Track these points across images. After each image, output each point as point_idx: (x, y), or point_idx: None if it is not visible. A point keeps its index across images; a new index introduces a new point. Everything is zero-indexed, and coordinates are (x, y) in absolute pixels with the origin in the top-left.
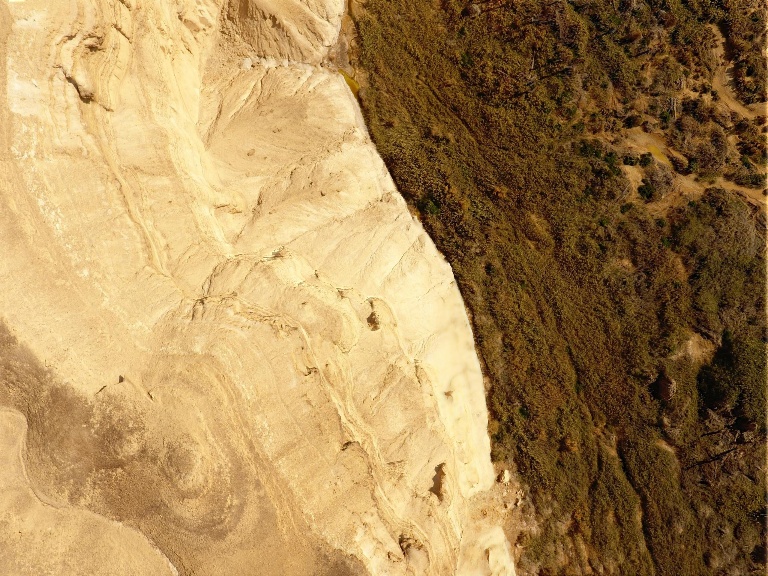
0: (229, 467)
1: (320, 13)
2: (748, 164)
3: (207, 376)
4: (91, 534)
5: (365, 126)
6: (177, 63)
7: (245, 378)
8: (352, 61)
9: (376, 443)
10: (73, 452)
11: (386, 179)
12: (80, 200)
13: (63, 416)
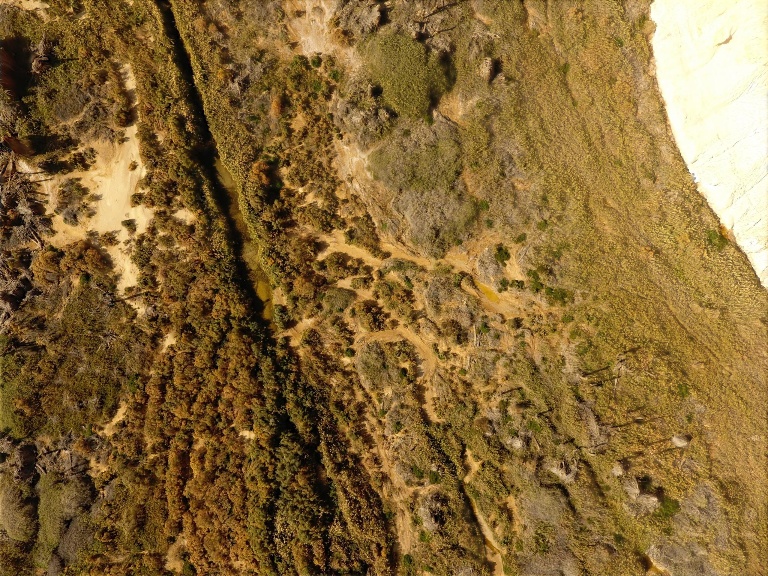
0: None
1: None
2: (408, 280)
3: None
4: None
5: None
6: None
7: None
8: None
9: None
10: None
11: (767, 263)
12: None
13: None
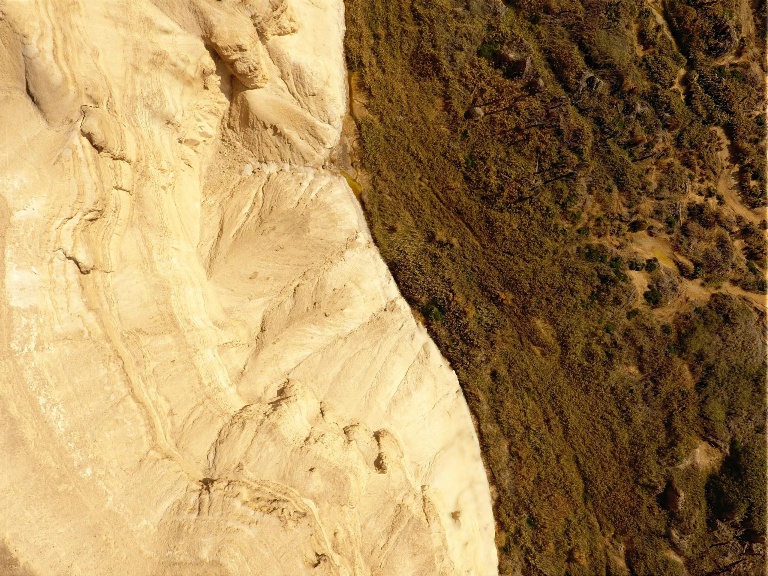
0: None
1: (321, 117)
2: (754, 270)
3: None
4: None
5: (368, 229)
6: (177, 186)
7: None
8: (354, 163)
9: None
10: None
11: (390, 286)
12: (82, 390)
13: None
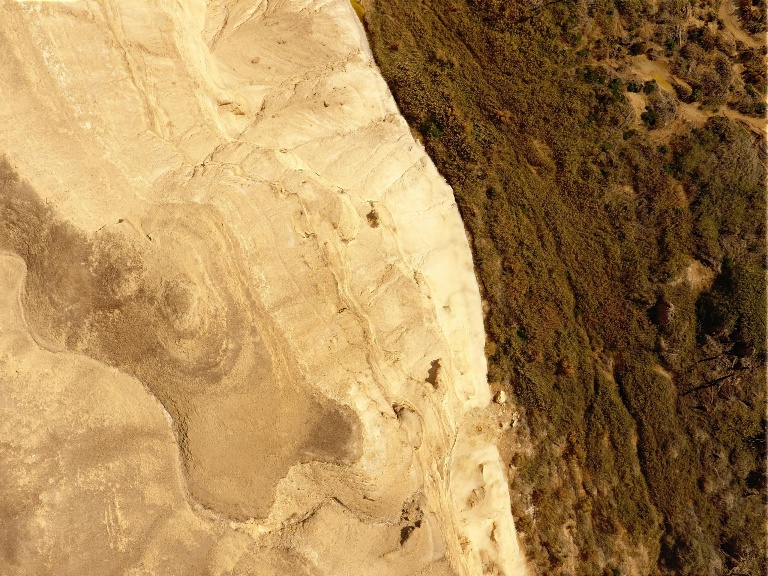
0: (225, 311)
1: None
2: (752, 92)
3: (206, 222)
4: (87, 377)
5: (370, 50)
6: None
7: (243, 230)
8: None
9: (373, 329)
10: (71, 291)
11: (389, 101)
12: (84, 58)
13: (62, 254)
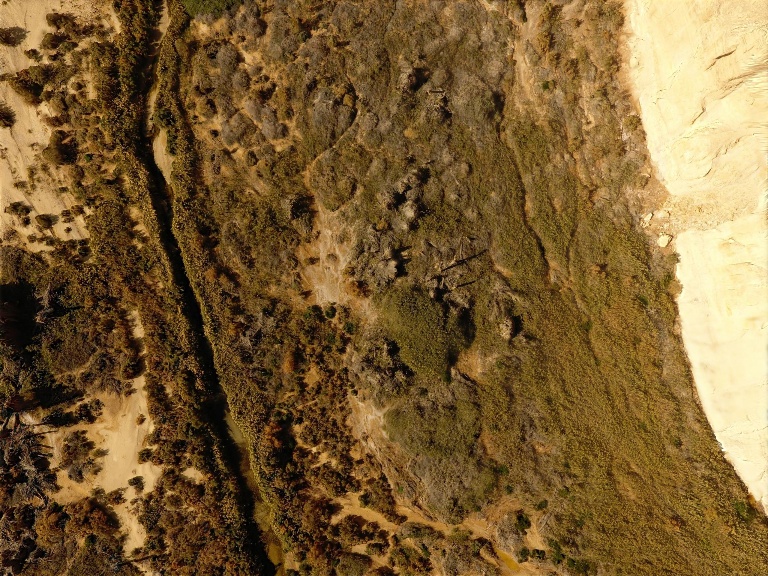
0: None
1: None
2: (425, 549)
3: None
4: None
5: None
6: None
7: None
8: None
9: None
10: None
11: None
12: None
13: None
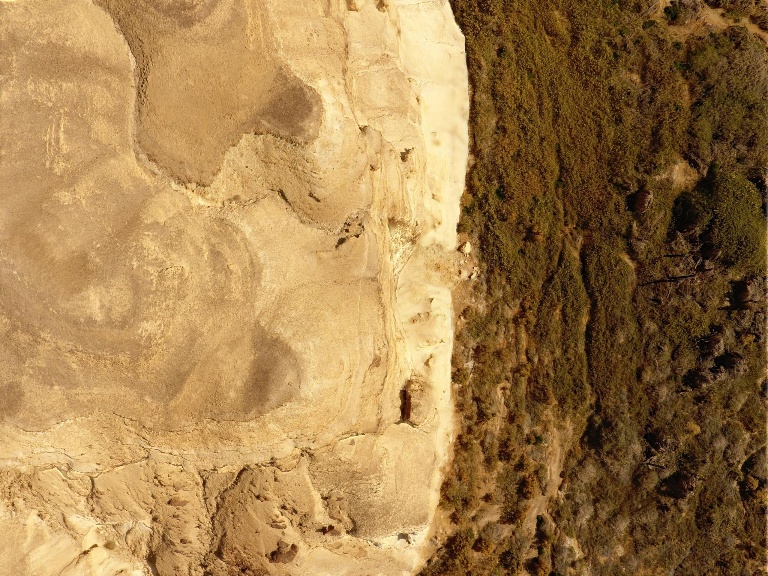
0: None
1: None
2: None
3: None
4: None
5: None
6: None
7: None
8: None
9: (355, 88)
10: None
11: None
12: None
13: None
